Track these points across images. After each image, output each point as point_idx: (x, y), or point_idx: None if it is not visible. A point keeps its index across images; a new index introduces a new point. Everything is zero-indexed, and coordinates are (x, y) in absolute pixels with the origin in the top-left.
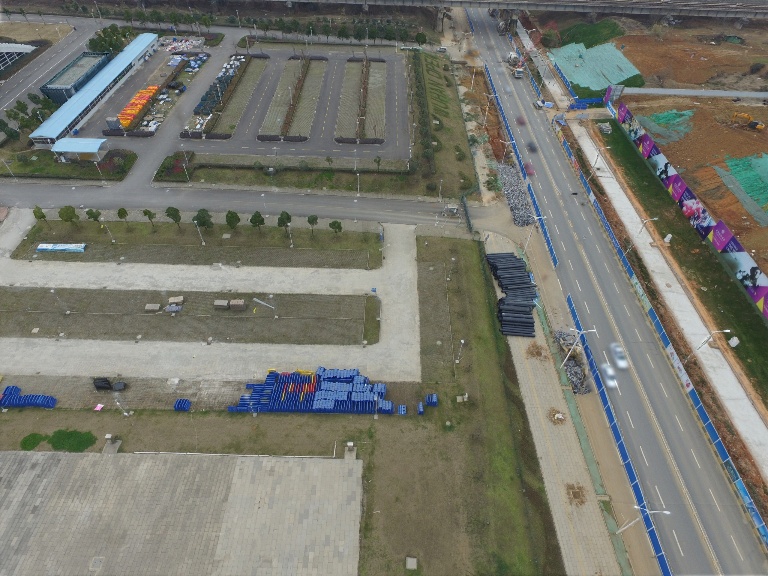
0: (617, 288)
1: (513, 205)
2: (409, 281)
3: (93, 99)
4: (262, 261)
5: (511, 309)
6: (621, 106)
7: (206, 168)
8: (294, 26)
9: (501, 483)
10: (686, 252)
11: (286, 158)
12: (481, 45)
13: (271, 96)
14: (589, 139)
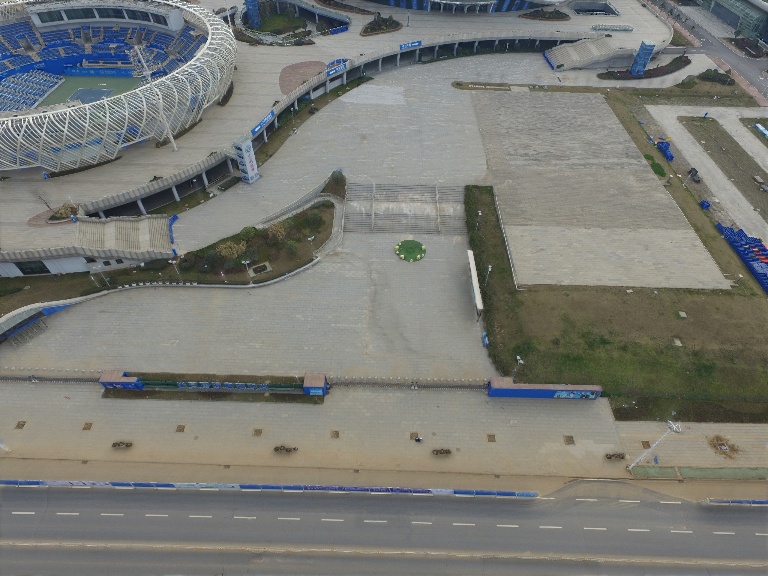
0: None
1: None
2: None
3: None
4: None
5: None
6: None
7: None
8: None
9: None
10: None
11: None
12: None
13: None
14: None
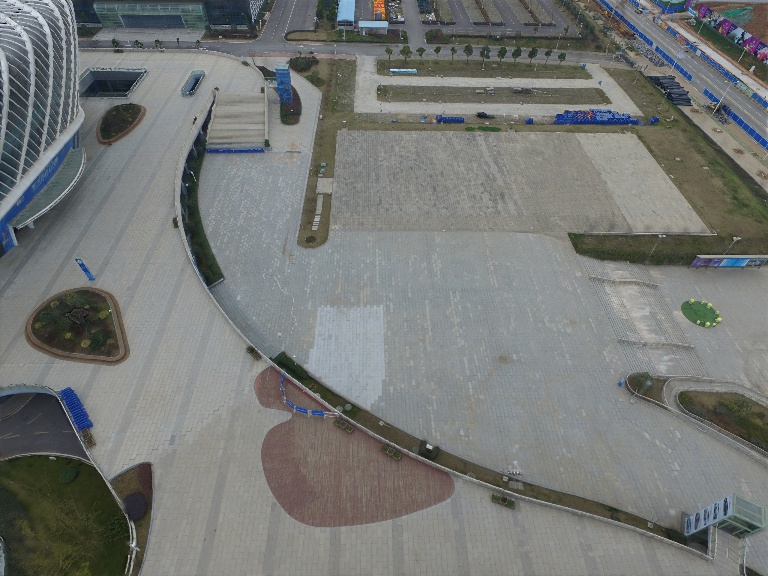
0: (729, 89)
1: (650, 57)
2: (613, 83)
3: None
4: (523, 76)
5: (676, 93)
6: (701, 7)
7: (455, 37)
8: None
9: None
10: (764, 75)
11: (500, 33)
12: None
13: (461, 4)
14: (682, 29)
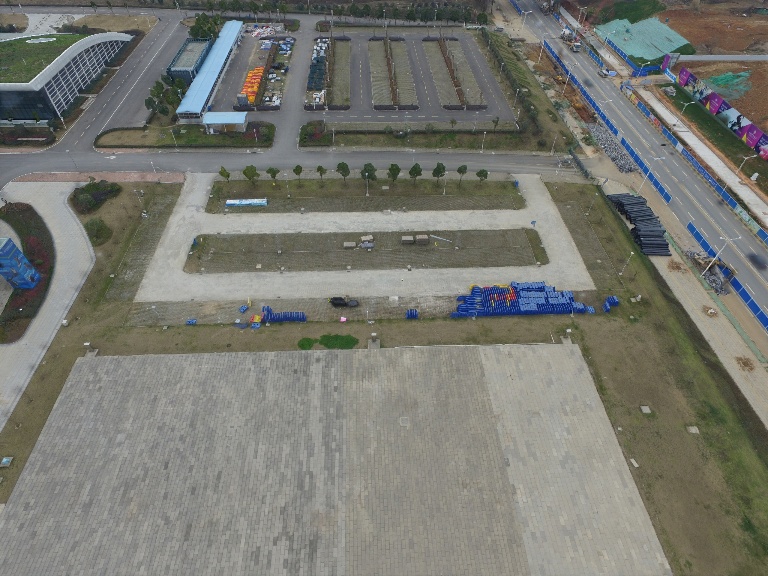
0: (724, 217)
1: (613, 156)
2: (554, 217)
3: (215, 79)
4: (424, 206)
5: (647, 234)
6: (682, 71)
7: (342, 134)
8: (366, 10)
9: (689, 356)
10: None
11: (408, 124)
12: (531, 24)
13: (368, 73)
14: (657, 101)
